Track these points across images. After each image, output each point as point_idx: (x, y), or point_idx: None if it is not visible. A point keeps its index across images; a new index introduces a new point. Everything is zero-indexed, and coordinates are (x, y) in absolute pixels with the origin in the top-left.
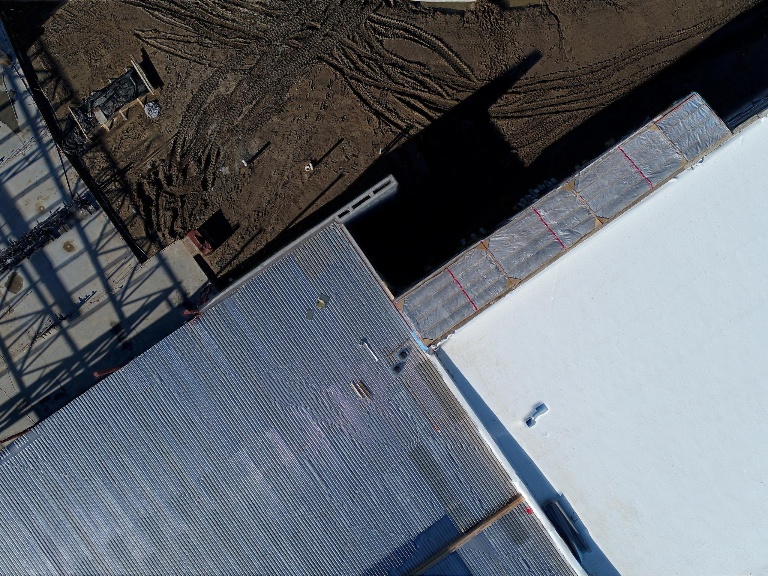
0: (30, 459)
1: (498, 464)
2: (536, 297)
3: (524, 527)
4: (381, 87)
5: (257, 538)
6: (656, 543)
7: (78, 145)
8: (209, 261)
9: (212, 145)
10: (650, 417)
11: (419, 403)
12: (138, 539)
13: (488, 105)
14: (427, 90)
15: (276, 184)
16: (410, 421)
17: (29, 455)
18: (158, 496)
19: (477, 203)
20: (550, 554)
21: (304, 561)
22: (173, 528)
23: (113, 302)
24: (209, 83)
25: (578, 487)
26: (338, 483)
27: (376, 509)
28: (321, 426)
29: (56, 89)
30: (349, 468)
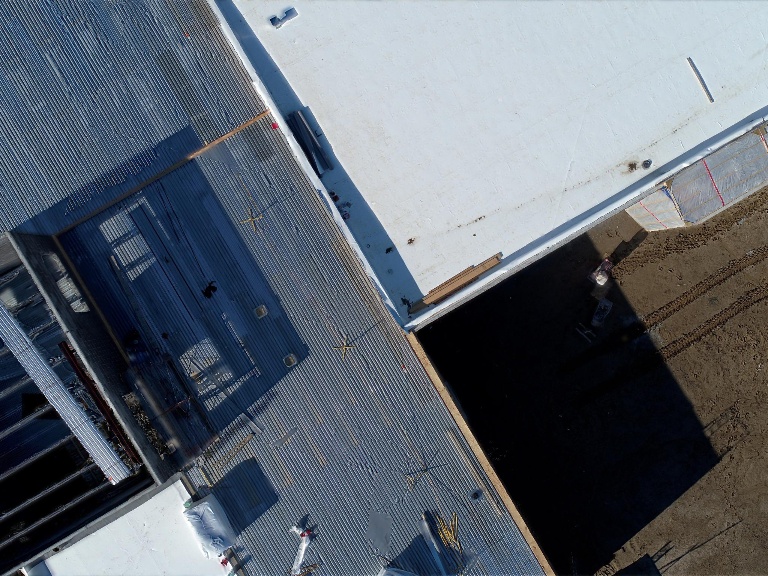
0: None
1: (248, 78)
2: None
3: (268, 141)
4: None
5: None
6: (402, 167)
7: None
8: None
9: None
10: (404, 33)
11: (170, 6)
12: None
13: None
14: None
15: None
16: (166, 35)
17: None
18: None
19: None
20: (293, 172)
21: (38, 158)
22: None
23: None
24: None
25: (324, 100)
26: (79, 81)
27: (117, 112)
28: (65, 20)
29: None
30: (92, 66)
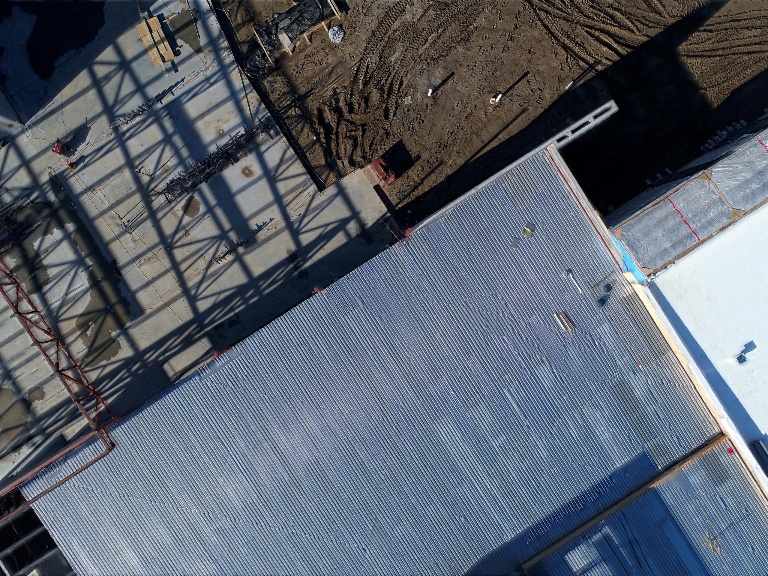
0: (230, 377)
1: (698, 402)
2: (751, 232)
3: (723, 465)
4: (570, 20)
5: (454, 466)
6: None
7: (260, 68)
8: (388, 192)
9: (395, 73)
10: None
11: (621, 337)
12: (335, 462)
13: (679, 42)
14: (617, 24)
15: (459, 116)
16: (606, 356)
17: (229, 373)
18: (357, 420)
19: (662, 143)
20: (747, 493)
21: (500, 491)
22: (370, 452)
23: (290, 230)
24: (395, 9)
25: None
26: (537, 414)
27: (574, 442)
28: (522, 356)
29: (239, 10)
30: (548, 399)
